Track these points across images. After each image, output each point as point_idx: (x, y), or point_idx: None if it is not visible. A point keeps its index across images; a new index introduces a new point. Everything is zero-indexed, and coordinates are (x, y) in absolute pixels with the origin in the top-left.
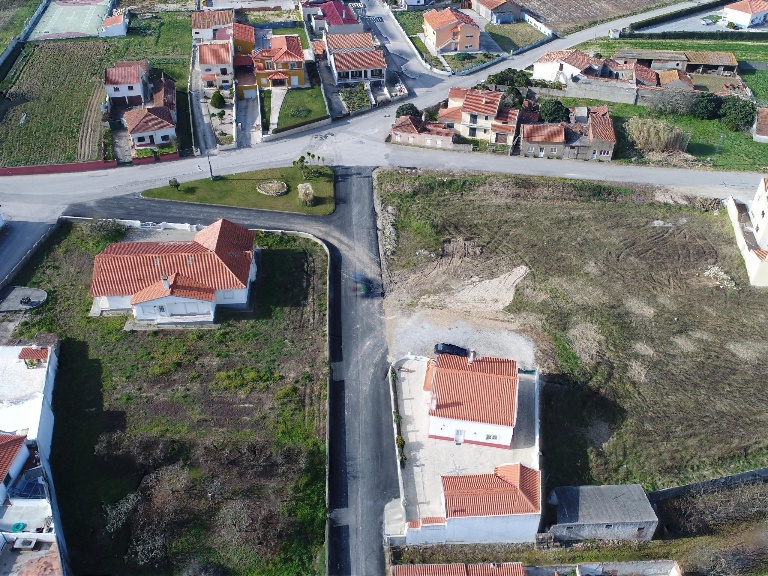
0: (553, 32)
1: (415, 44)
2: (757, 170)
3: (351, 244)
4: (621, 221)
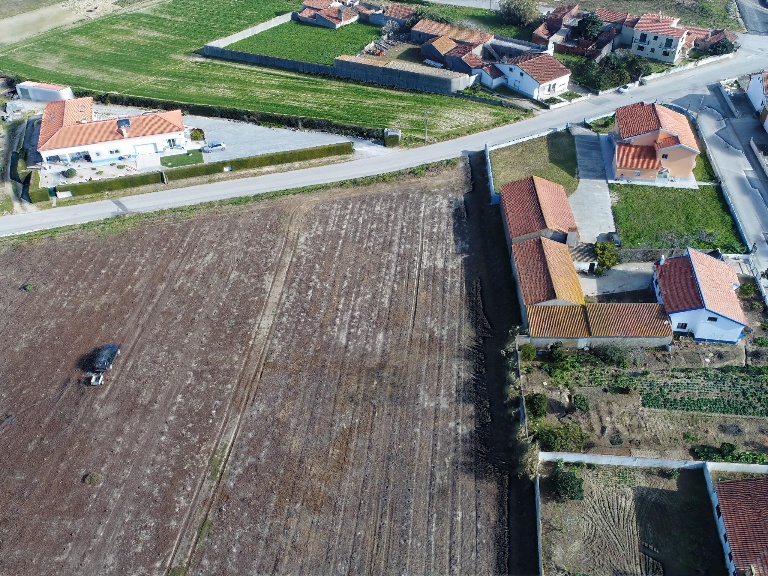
0: (470, 166)
1: (705, 162)
2: (462, 6)
3: (756, 7)
4: (580, 3)
